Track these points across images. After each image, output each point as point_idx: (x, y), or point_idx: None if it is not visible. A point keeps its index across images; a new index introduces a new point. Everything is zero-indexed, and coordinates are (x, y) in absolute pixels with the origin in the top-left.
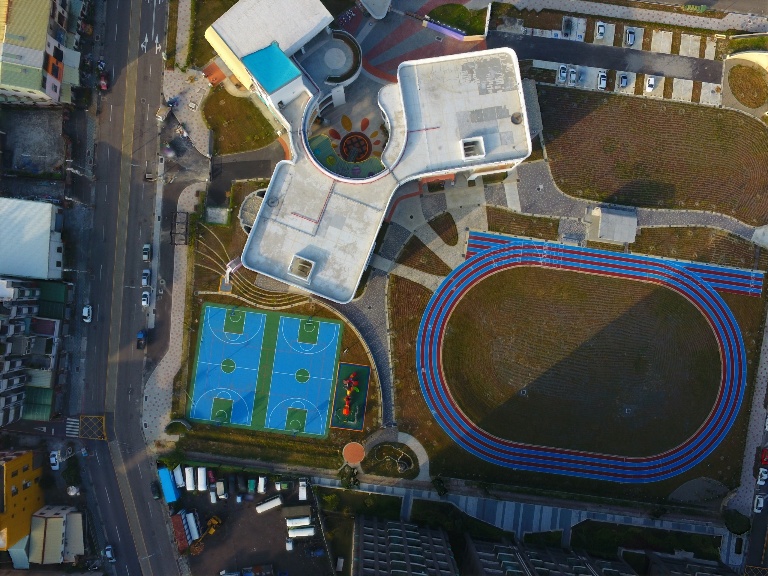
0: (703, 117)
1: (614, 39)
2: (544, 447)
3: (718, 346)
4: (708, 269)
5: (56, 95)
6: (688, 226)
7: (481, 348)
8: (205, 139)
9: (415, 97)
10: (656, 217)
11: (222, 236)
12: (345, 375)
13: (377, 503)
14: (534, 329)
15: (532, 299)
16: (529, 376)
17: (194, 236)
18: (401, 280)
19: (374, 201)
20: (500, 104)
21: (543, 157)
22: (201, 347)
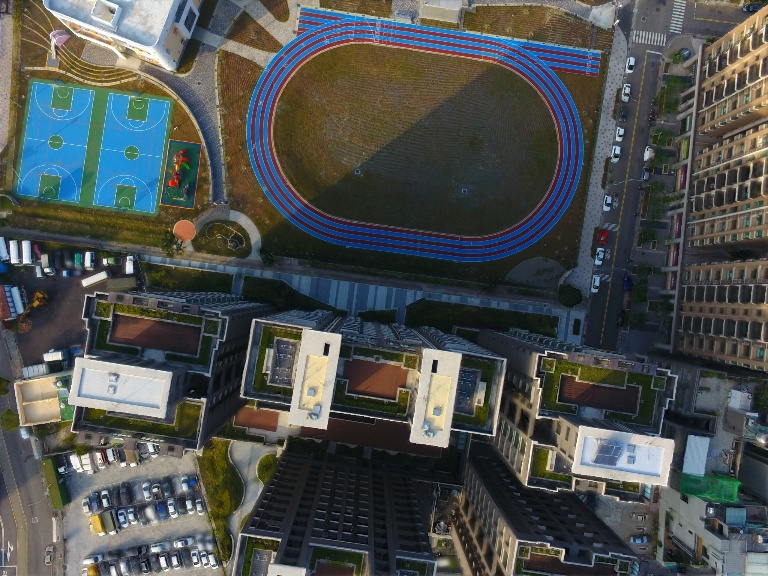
0: None
1: None
2: (377, 225)
3: (555, 126)
4: (544, 48)
5: None
6: (524, 5)
7: (314, 126)
8: None
9: None
10: None
11: None
12: (175, 152)
13: (207, 280)
14: (368, 108)
15: (366, 77)
16: (363, 155)
17: (19, 9)
18: (231, 56)
19: None
20: None
21: None
22: (28, 123)
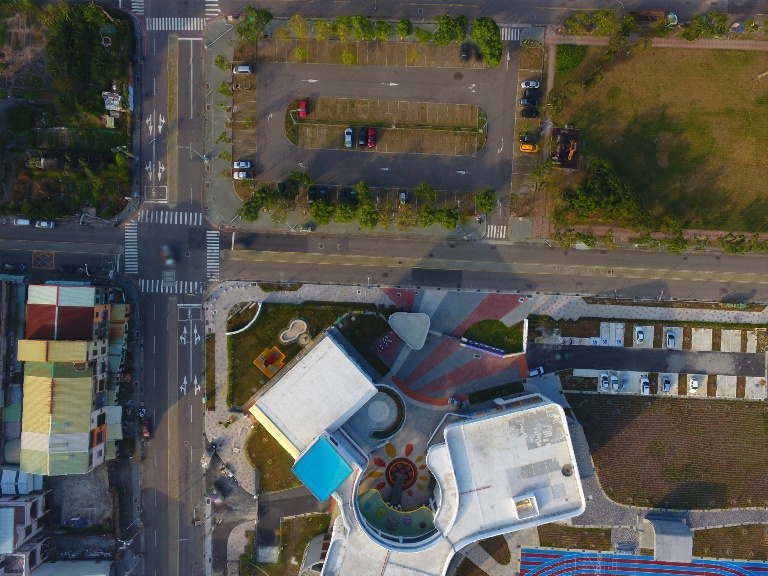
0: (749, 412)
1: (654, 341)
2: None
3: None
4: (765, 567)
5: (101, 457)
6: (742, 524)
7: None
8: (250, 478)
9: (464, 458)
10: (709, 518)
11: (274, 575)
12: None
13: None
14: None
15: None
16: None
17: None
18: None
19: (430, 567)
20: (550, 457)
21: None
22: None
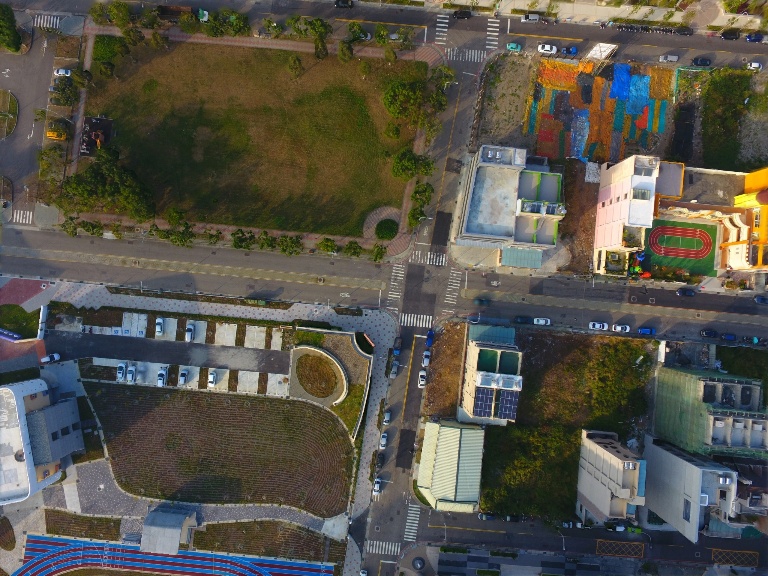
0: (270, 409)
1: (176, 334)
2: None
3: None
4: (276, 564)
5: None
6: (255, 520)
7: None
8: None
9: None
10: (222, 513)
11: None
12: None
13: None
14: None
15: None
16: None
17: None
18: None
19: None
20: (4, 441)
21: (104, 456)
22: None
